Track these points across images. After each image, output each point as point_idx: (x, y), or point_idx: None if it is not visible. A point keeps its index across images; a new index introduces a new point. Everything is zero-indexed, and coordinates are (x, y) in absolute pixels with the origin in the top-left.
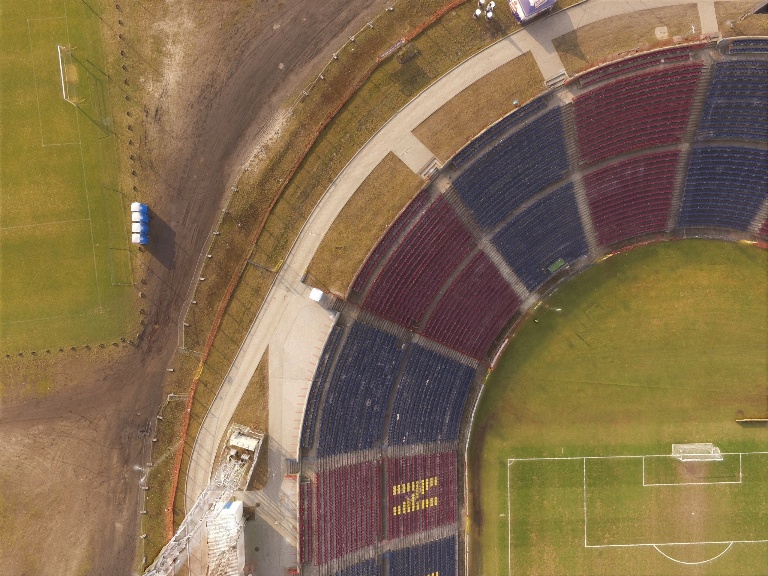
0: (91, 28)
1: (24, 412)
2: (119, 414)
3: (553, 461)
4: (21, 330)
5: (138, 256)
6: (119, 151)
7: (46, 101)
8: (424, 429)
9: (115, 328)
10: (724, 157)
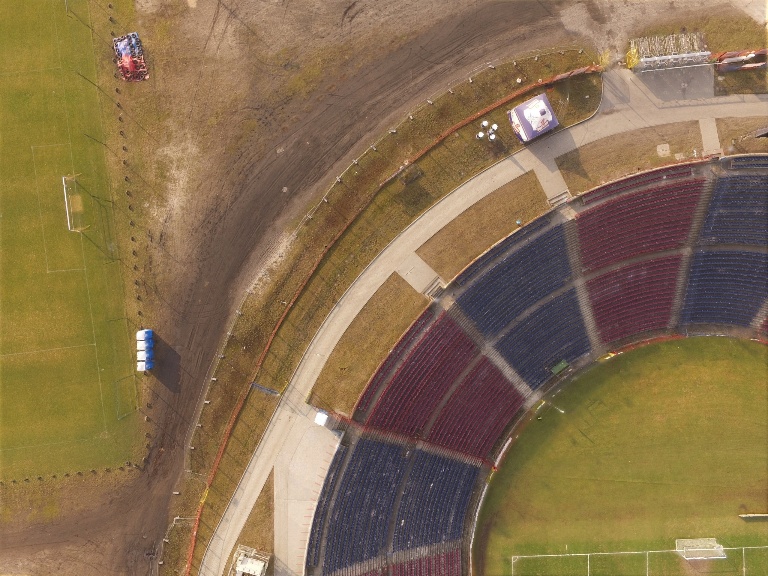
0: (95, 154)
1: (30, 537)
2: (125, 537)
3: (557, 558)
4: (27, 456)
5: (143, 380)
6: (124, 276)
7: (51, 227)
8: (428, 531)
9: (121, 452)
10: (726, 260)
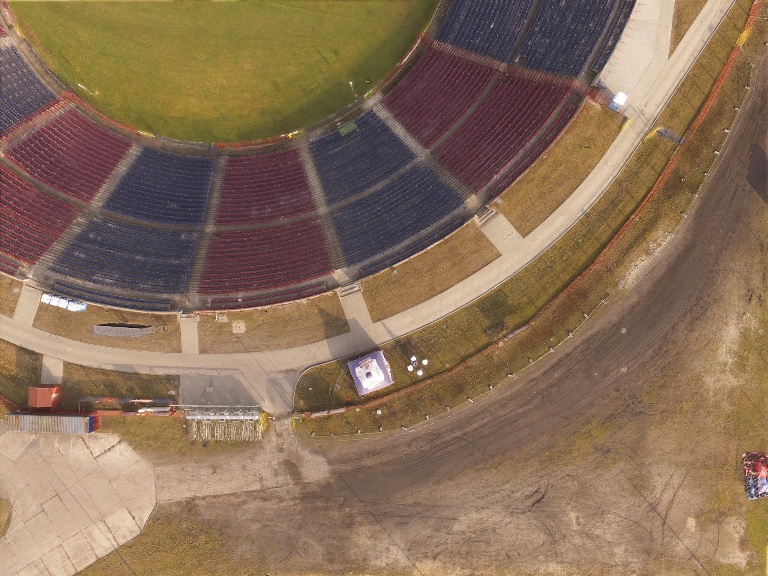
0: None
1: None
2: None
3: None
4: None
5: None
6: None
7: None
8: None
9: None
10: (169, 215)
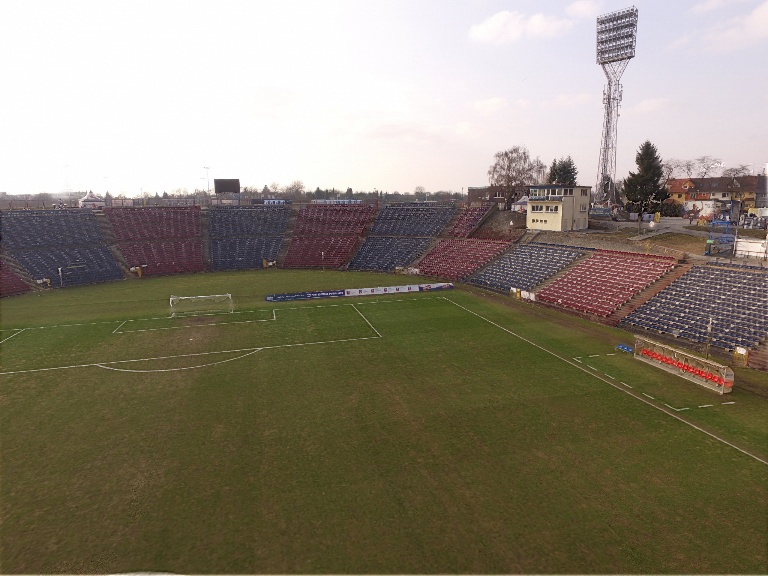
0: None
1: None
2: None
3: None
4: None
5: None
6: None
7: None
8: None
9: None
10: None
